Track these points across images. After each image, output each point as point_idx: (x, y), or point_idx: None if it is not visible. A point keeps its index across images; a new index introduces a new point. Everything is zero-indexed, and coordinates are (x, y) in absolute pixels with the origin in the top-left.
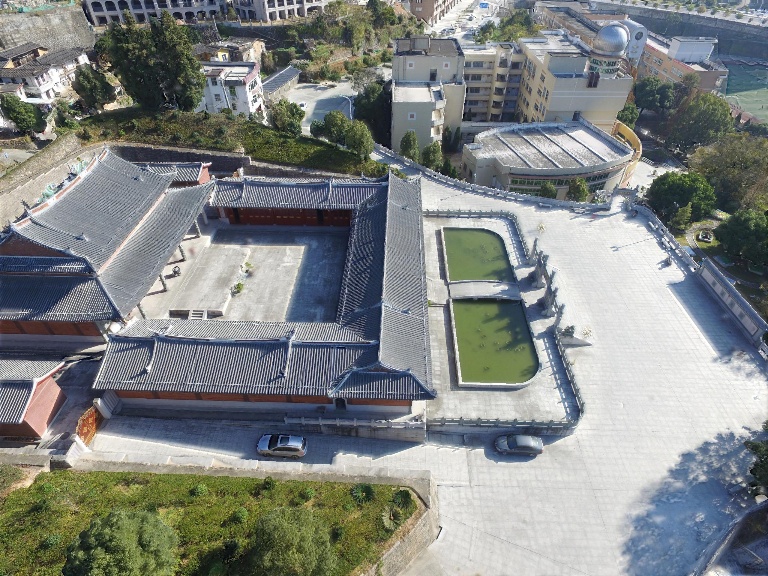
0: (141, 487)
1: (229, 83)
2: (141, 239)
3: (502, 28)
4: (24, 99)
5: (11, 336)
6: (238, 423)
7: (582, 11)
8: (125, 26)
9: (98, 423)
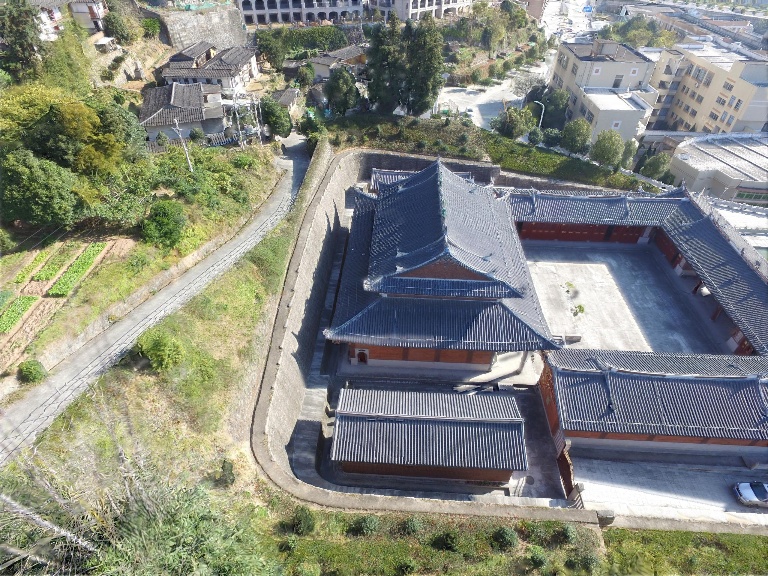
0: (714, 550)
1: None
2: None
3: (618, 33)
4: (222, 101)
5: (387, 362)
6: (697, 468)
7: (699, 17)
8: (273, 25)
9: (560, 466)
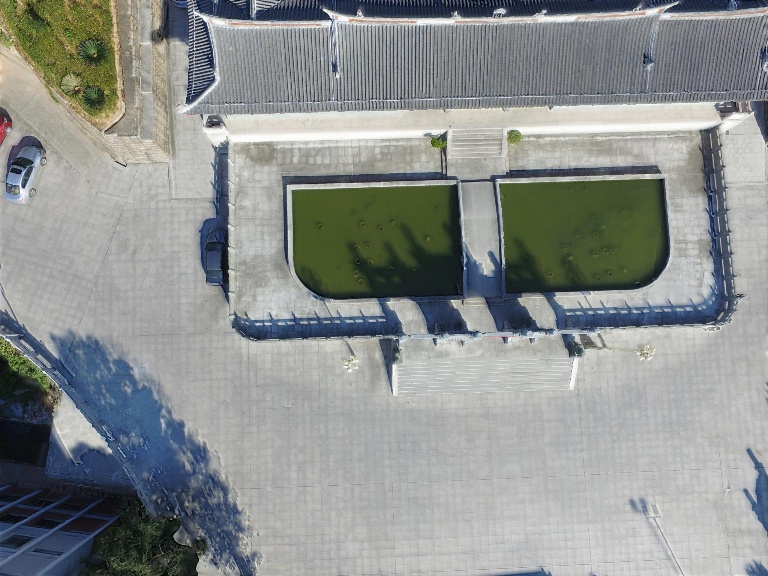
0: None
1: None
2: None
3: None
4: None
5: None
6: None
7: None
8: None
9: None
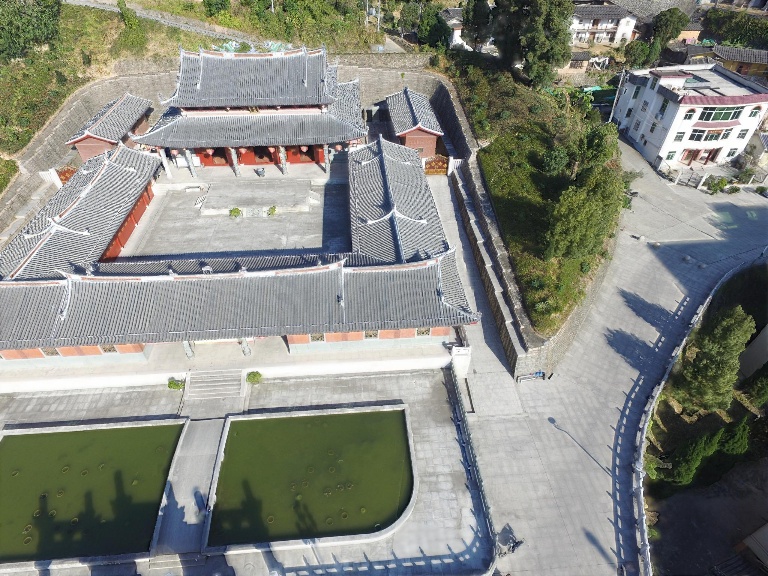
0: None
1: (666, 93)
2: (245, 122)
3: None
4: None
5: None
6: None
7: None
8: (743, 9)
9: None
